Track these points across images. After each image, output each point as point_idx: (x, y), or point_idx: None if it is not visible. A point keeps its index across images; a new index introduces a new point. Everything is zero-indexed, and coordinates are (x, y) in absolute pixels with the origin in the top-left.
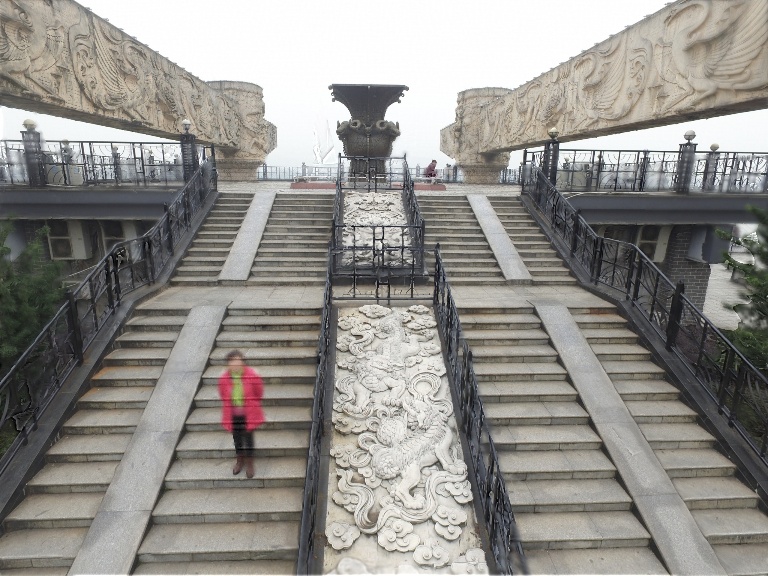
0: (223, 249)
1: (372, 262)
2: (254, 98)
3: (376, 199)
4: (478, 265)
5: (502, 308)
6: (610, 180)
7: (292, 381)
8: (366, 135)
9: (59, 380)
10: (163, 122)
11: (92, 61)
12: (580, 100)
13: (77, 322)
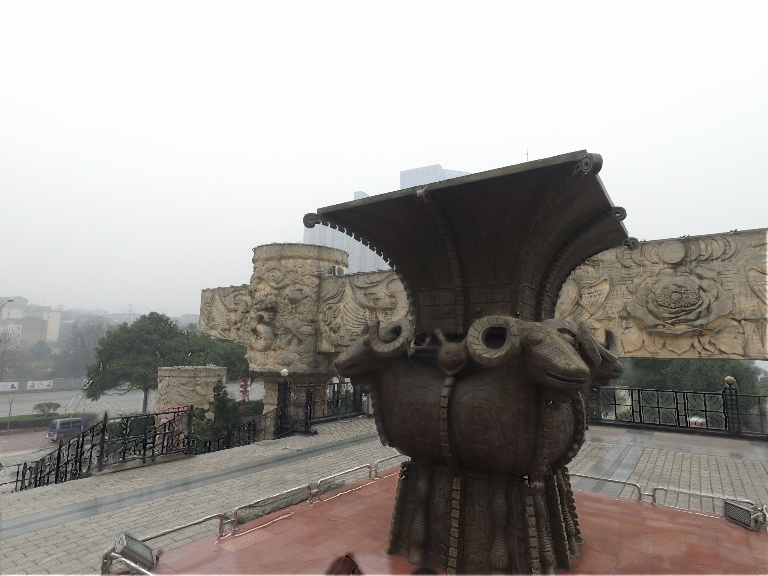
0: None
1: None
2: None
3: None
4: None
5: None
6: None
7: None
8: None
9: None
10: (644, 343)
11: None
12: None
13: None
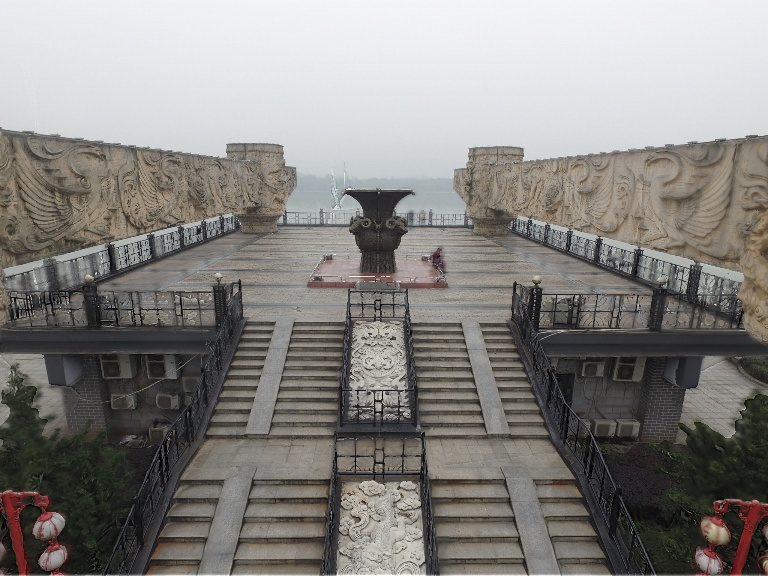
0: (249, 394)
1: (373, 417)
2: (275, 157)
3: (380, 332)
4: (465, 413)
5: (478, 480)
6: (589, 319)
7: (303, 562)
8: (376, 231)
9: (128, 570)
10: (194, 214)
11: (136, 191)
12: (575, 200)
13: (140, 516)
